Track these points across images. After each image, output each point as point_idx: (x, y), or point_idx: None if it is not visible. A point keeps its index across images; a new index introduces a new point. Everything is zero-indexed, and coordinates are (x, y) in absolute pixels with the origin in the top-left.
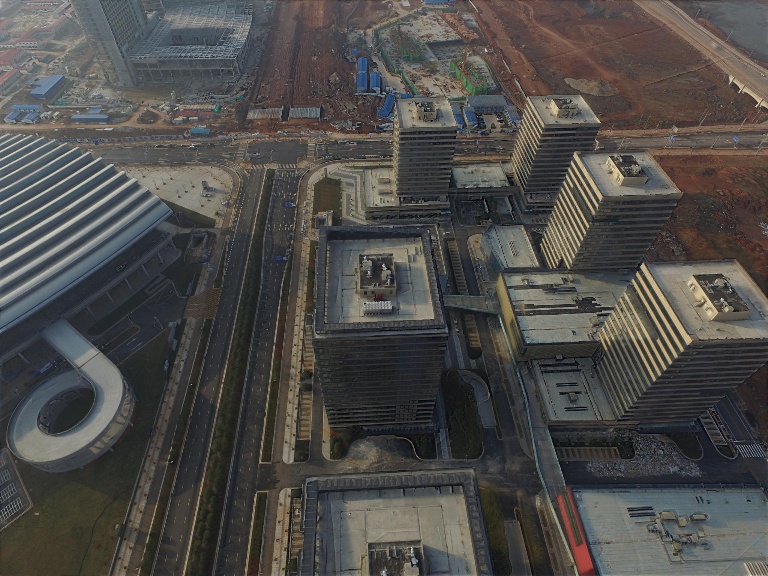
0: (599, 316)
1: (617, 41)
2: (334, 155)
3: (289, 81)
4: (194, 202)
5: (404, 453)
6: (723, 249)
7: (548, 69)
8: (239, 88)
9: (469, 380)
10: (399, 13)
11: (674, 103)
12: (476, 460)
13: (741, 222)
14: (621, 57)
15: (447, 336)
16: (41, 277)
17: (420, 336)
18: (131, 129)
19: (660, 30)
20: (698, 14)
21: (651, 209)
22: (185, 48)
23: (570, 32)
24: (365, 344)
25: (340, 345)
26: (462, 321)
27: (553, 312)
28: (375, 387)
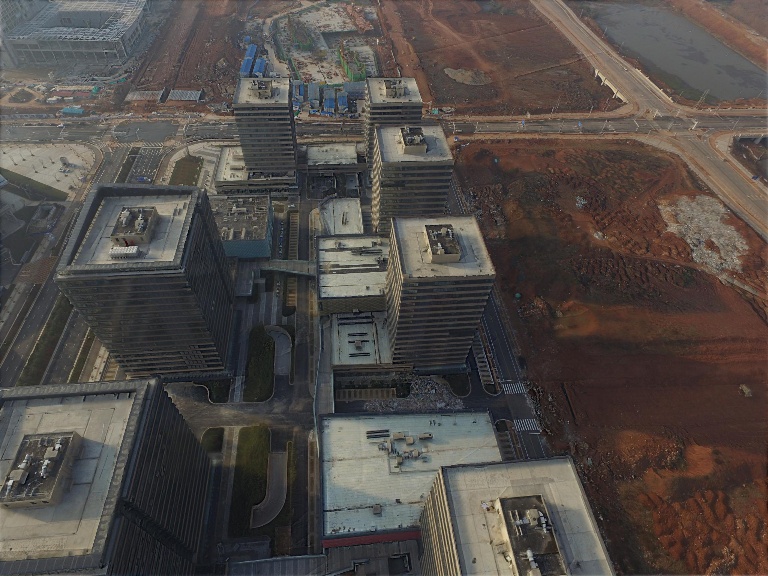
0: None
1: (503, 36)
2: (203, 135)
3: (176, 65)
4: (50, 177)
5: (198, 398)
6: (536, 219)
7: (432, 60)
8: (123, 71)
9: (279, 335)
10: (303, 4)
11: (538, 92)
12: (264, 402)
13: (560, 196)
14: (503, 50)
15: (184, 276)
16: None
17: (158, 276)
18: (0, 107)
19: (546, 27)
20: (586, 13)
21: (431, 175)
22: (67, 30)
23: (462, 26)
24: (109, 284)
25: (85, 285)
26: (284, 283)
27: (355, 271)
28: (146, 331)
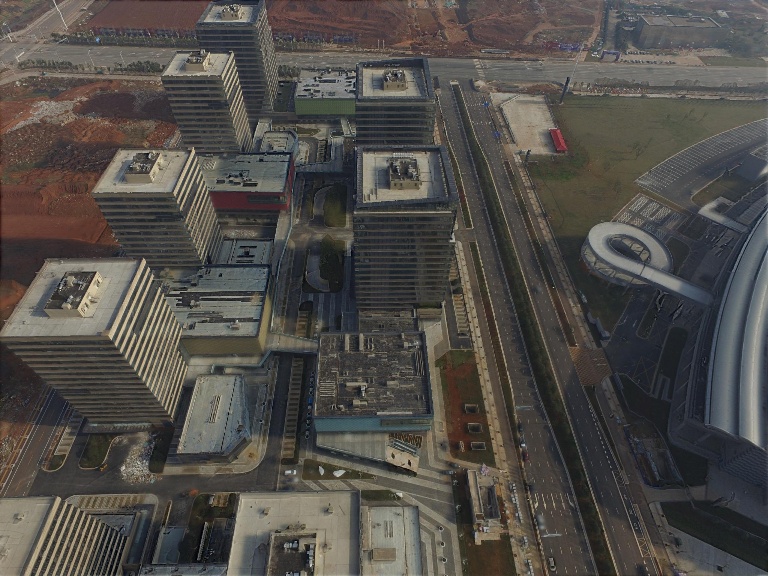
0: (187, 287)
1: None
2: None
3: None
4: None
5: None
6: None
7: None
8: None
9: None
10: None
11: None
12: None
13: None
14: None
15: None
16: (757, 308)
17: None
18: None
19: None
20: None
21: None
22: None
23: None
24: None
25: None
26: (309, 335)
27: (227, 293)
28: None
